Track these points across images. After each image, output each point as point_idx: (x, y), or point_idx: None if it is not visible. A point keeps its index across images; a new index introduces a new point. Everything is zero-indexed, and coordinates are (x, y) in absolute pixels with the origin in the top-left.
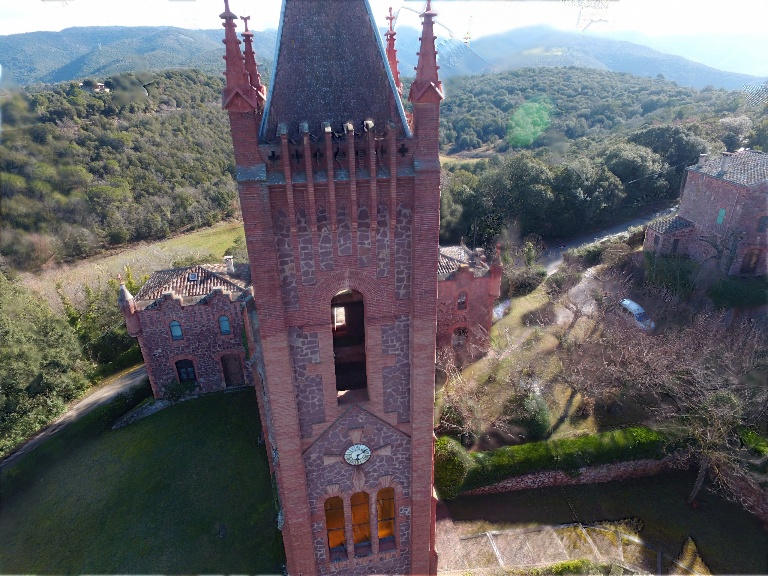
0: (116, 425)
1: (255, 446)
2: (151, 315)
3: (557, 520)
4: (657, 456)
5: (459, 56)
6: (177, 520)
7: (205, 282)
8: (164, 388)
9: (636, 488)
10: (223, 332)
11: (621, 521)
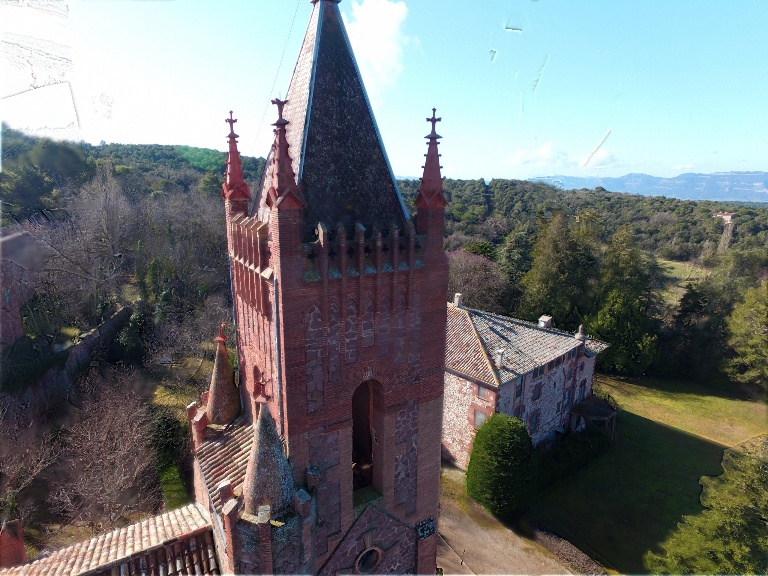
0: None
1: None
2: None
3: None
4: None
5: (38, 147)
6: None
7: None
8: None
9: None
10: None
11: None
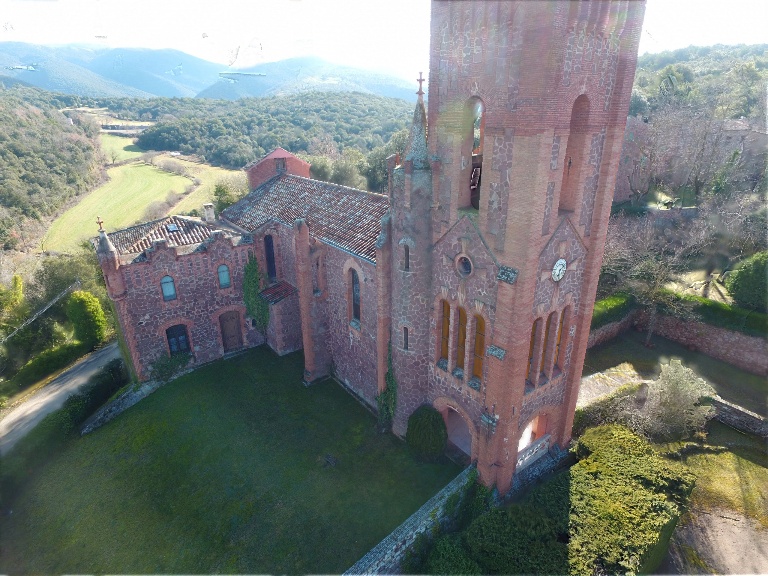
0: (87, 428)
1: (304, 389)
2: (138, 271)
3: (585, 374)
4: (619, 318)
5: None
6: (268, 471)
7: (191, 231)
8: (151, 366)
9: (612, 346)
10: (222, 285)
11: (619, 365)
